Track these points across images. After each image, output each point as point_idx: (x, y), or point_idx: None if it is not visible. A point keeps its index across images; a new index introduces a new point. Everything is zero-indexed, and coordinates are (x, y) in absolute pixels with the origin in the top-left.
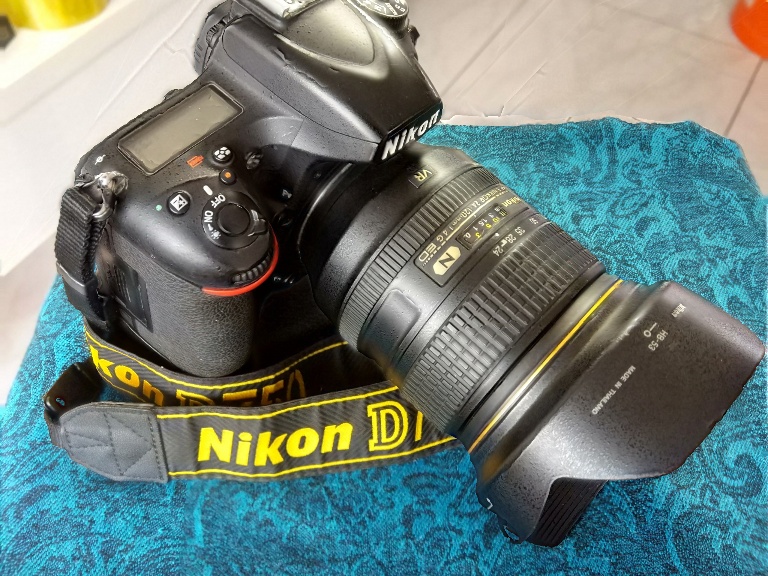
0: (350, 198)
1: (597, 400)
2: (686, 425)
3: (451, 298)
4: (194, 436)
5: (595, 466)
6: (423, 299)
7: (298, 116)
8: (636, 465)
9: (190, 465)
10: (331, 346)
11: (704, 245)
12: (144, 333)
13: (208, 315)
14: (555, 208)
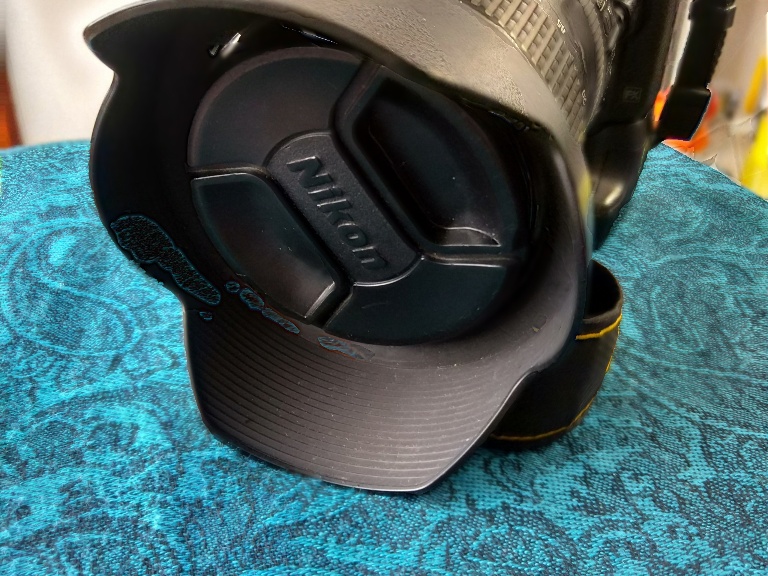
0: None
1: None
2: None
3: None
4: None
5: None
6: None
7: None
8: None
9: None
10: None
11: None
12: None
13: None
14: None
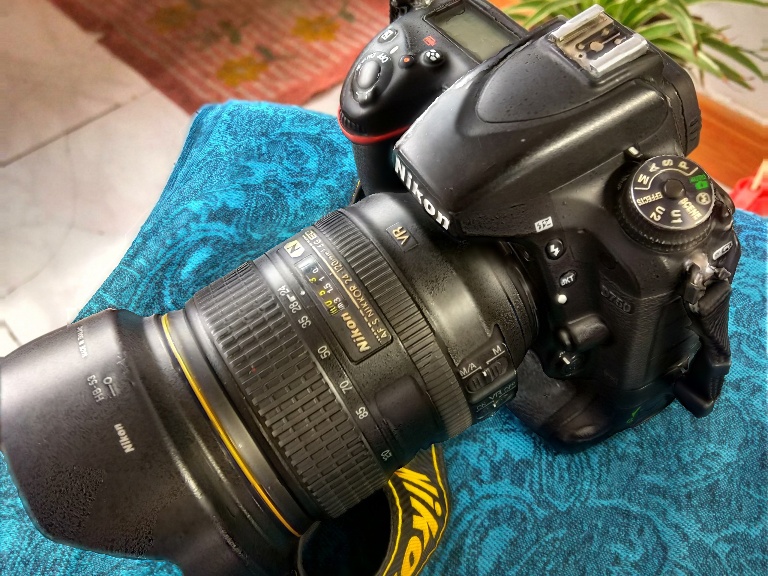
0: None
1: (86, 329)
2: (8, 382)
3: None
4: None
5: None
6: None
7: None
8: None
9: None
10: None
11: None
12: None
13: None
14: None
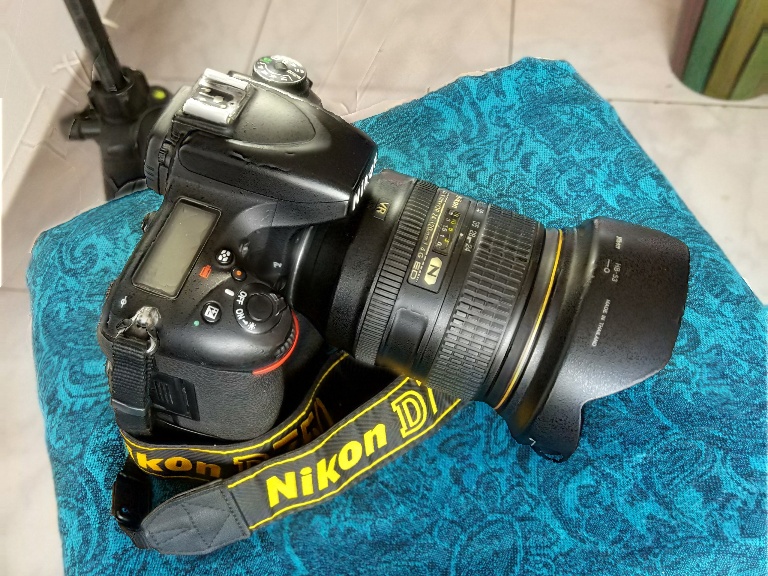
0: (330, 248)
1: (593, 335)
2: (662, 328)
3: (448, 299)
4: (262, 489)
5: (609, 384)
6: (426, 308)
7: (271, 201)
8: (639, 371)
9: (265, 514)
10: (332, 366)
11: (579, 161)
12: (188, 424)
13: (258, 390)
14: (451, 173)
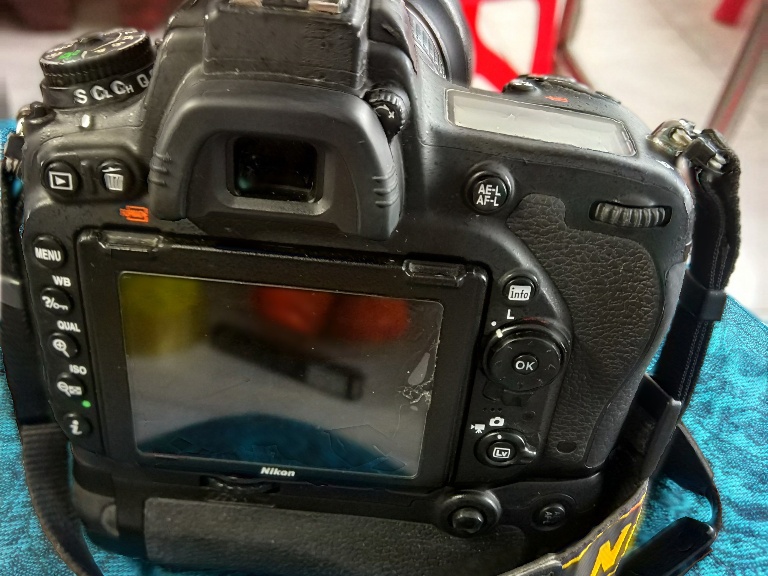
0: None
1: None
2: None
3: None
4: None
5: None
6: None
7: None
8: None
9: None
10: None
11: None
12: None
13: None
14: None
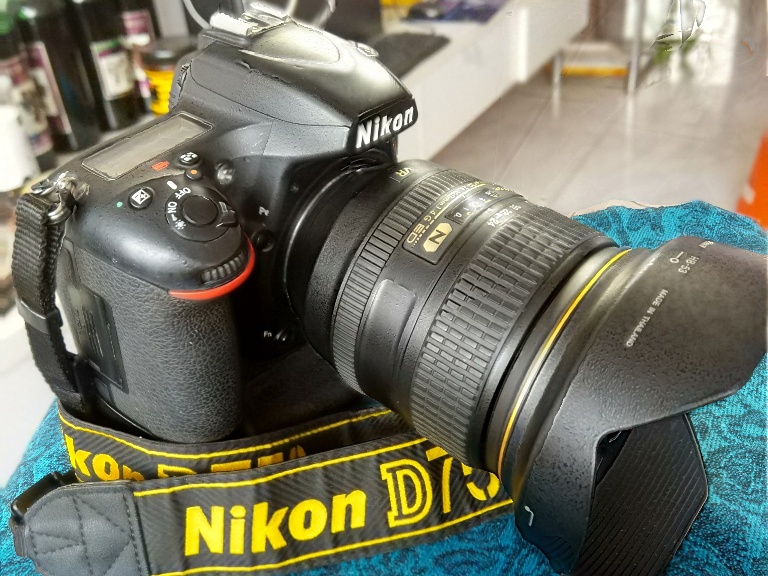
0: (331, 207)
1: (629, 331)
2: (743, 335)
3: (447, 274)
4: (179, 519)
5: (643, 406)
6: (417, 282)
7: (267, 120)
8: (693, 391)
9: (176, 562)
10: (338, 423)
11: None
12: (121, 401)
13: (180, 334)
14: None
